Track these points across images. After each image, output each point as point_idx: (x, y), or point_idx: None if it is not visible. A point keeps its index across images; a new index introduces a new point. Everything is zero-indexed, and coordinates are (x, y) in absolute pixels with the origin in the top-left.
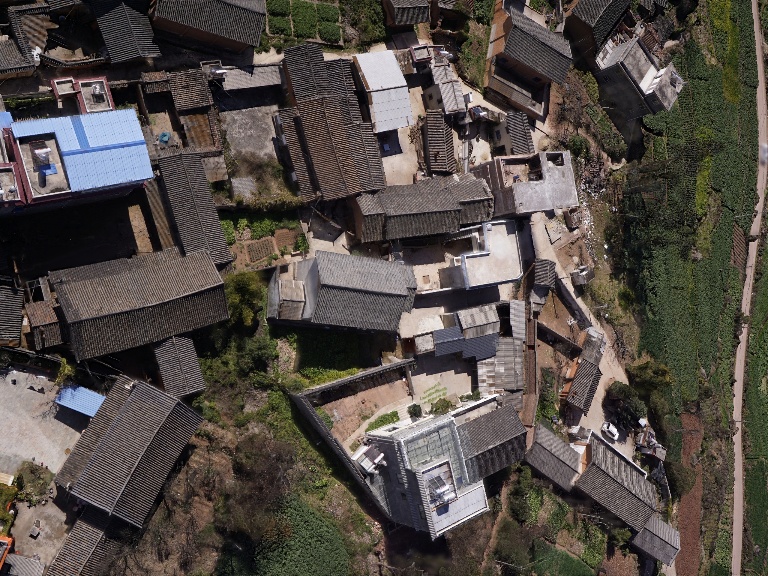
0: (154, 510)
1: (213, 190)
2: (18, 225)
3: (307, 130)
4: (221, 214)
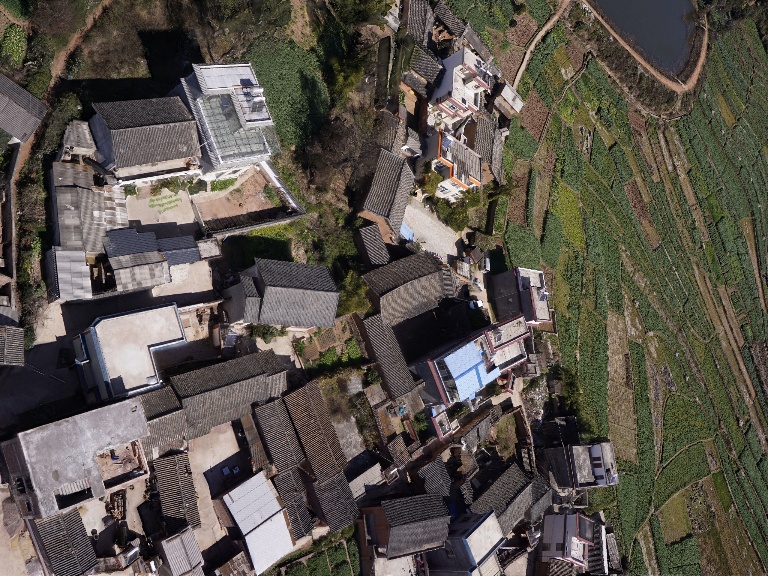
0: (365, 158)
1: (367, 380)
2: (440, 340)
3: (337, 441)
4: (359, 363)
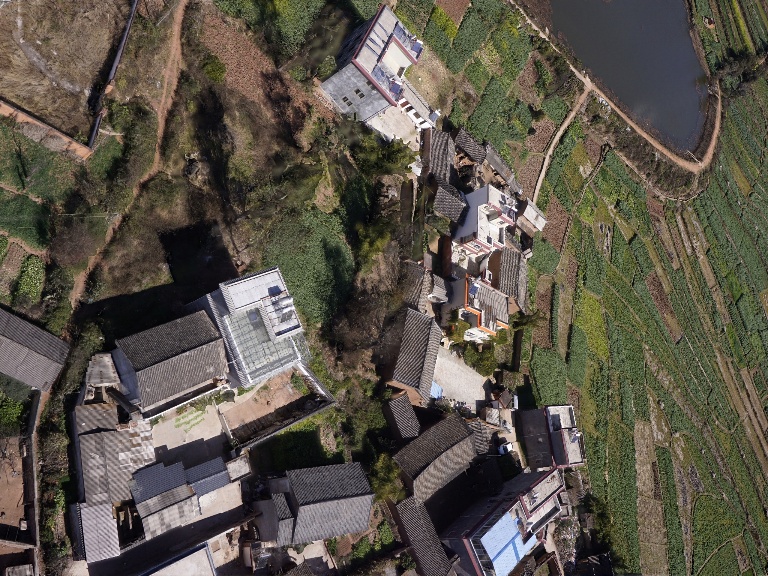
0: (392, 319)
1: (401, 565)
2: (471, 498)
3: None
4: (392, 548)
